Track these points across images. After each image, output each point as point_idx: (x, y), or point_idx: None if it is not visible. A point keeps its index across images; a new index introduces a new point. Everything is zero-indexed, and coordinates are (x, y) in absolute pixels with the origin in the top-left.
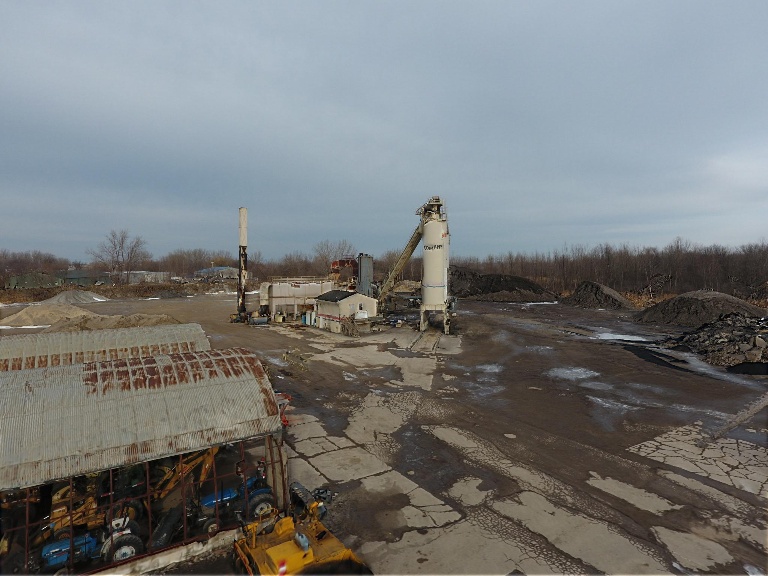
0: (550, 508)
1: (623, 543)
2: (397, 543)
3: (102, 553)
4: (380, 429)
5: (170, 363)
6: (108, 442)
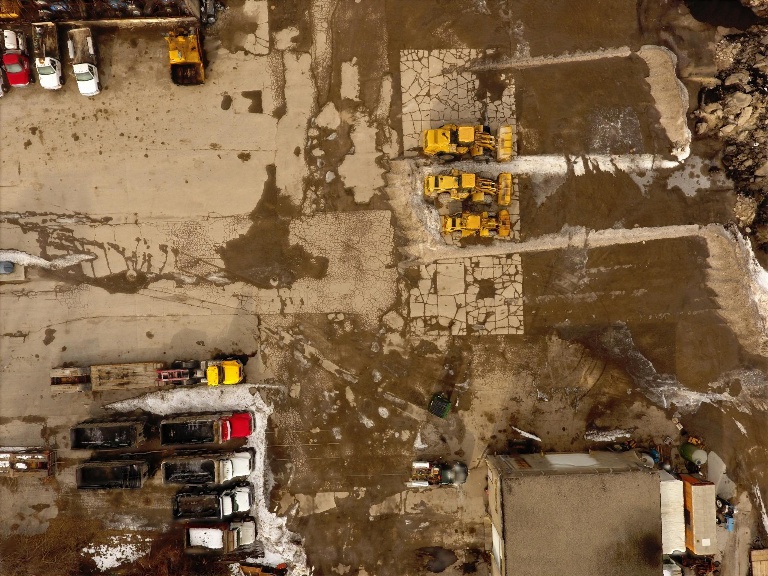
0: (305, 70)
1: (309, 102)
2: (232, 55)
3: (129, 10)
4: None
5: None
6: None
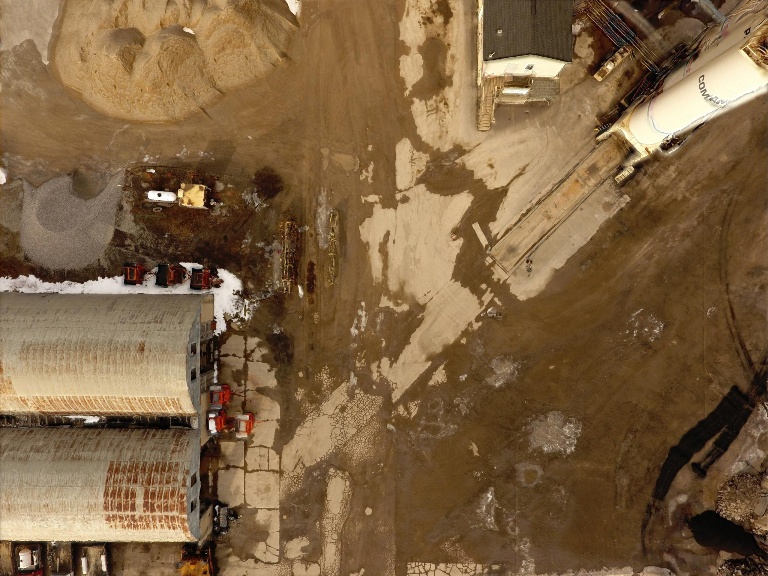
0: None
1: None
2: (243, 563)
3: None
4: (305, 458)
5: (142, 514)
6: None
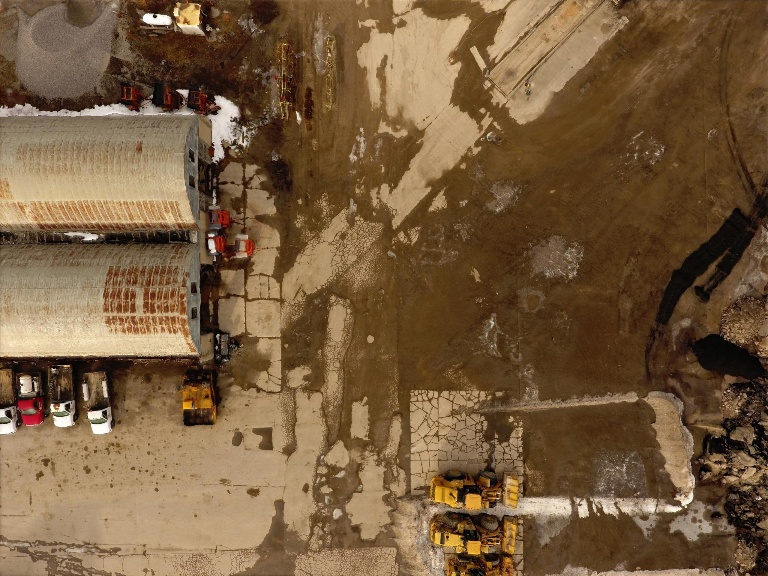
0: (316, 409)
1: (319, 440)
2: (245, 392)
3: None
4: (305, 286)
5: (142, 315)
6: (125, 350)
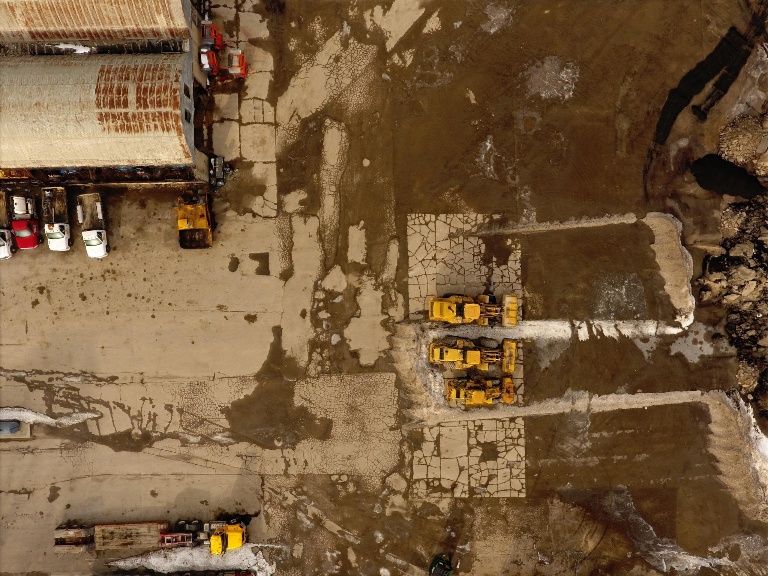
0: (313, 233)
1: (316, 265)
2: (240, 217)
3: None
4: (300, 109)
5: (135, 111)
6: None
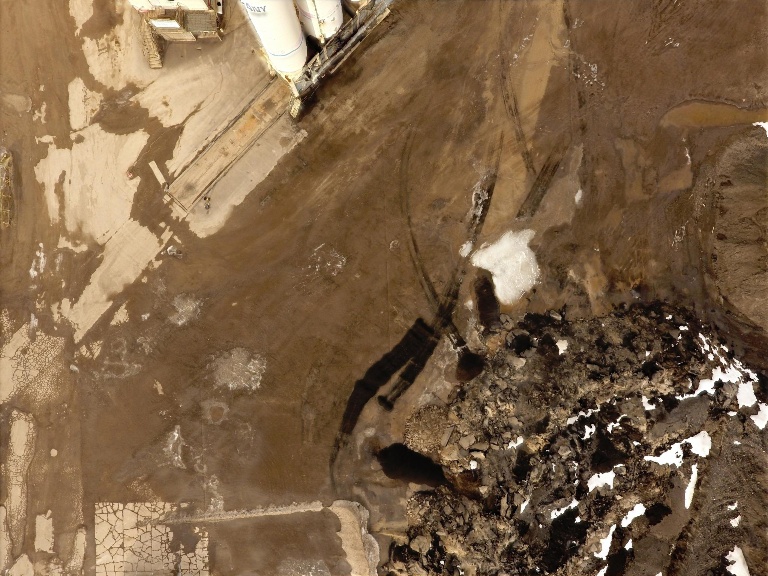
0: None
1: (3, 554)
2: None
3: None
4: None
5: None
6: None
